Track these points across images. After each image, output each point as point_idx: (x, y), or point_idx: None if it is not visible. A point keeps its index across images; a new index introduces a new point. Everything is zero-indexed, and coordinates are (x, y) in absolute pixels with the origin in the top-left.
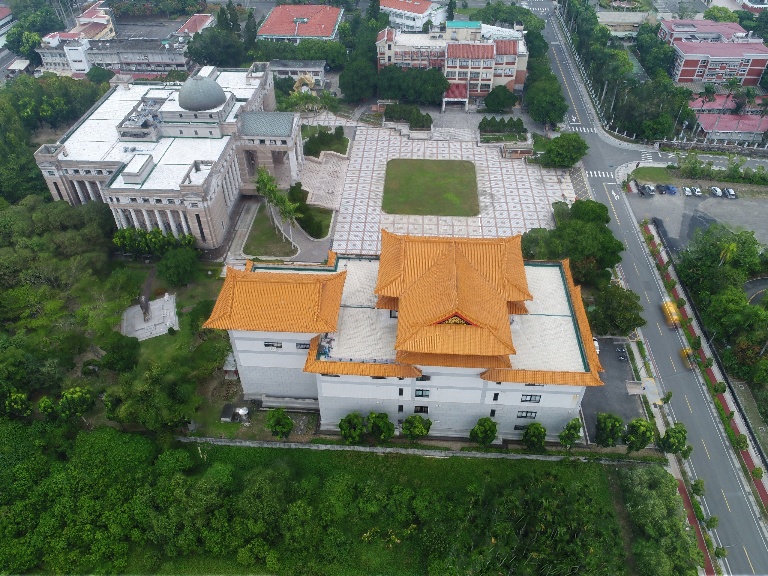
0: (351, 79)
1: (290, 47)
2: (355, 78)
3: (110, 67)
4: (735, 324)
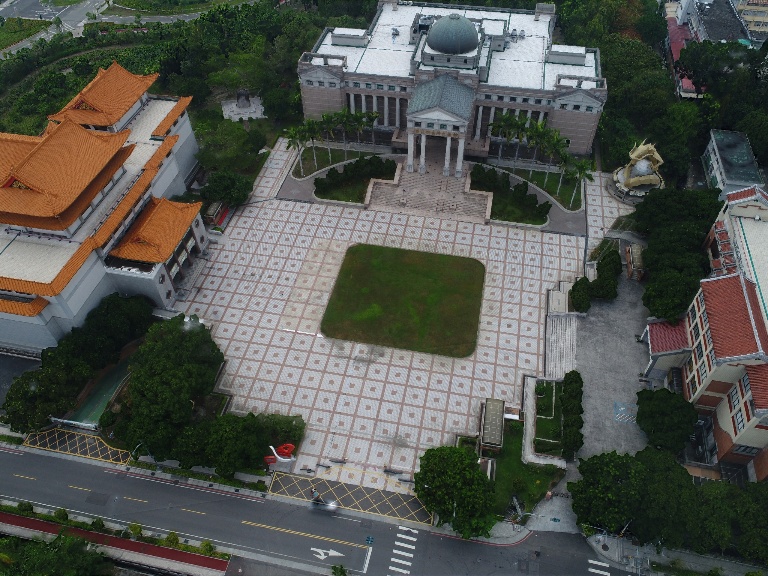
0: None
1: None
2: (653, 195)
3: (692, 31)
4: None
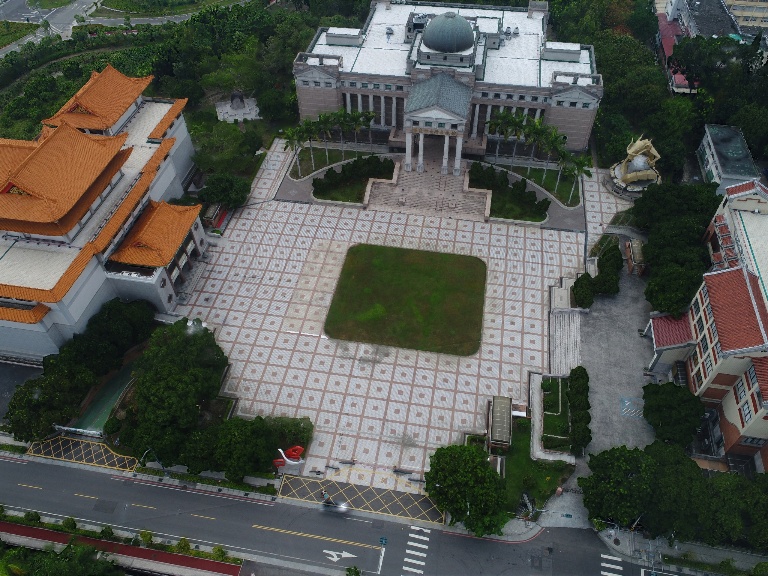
0: None
1: None
2: (652, 190)
3: (682, 27)
4: None
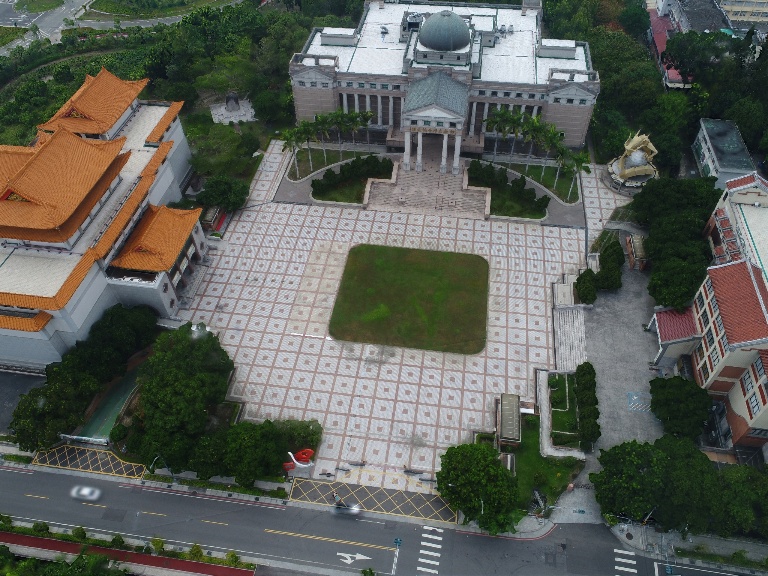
0: None
1: None
2: (651, 185)
3: (673, 22)
4: None
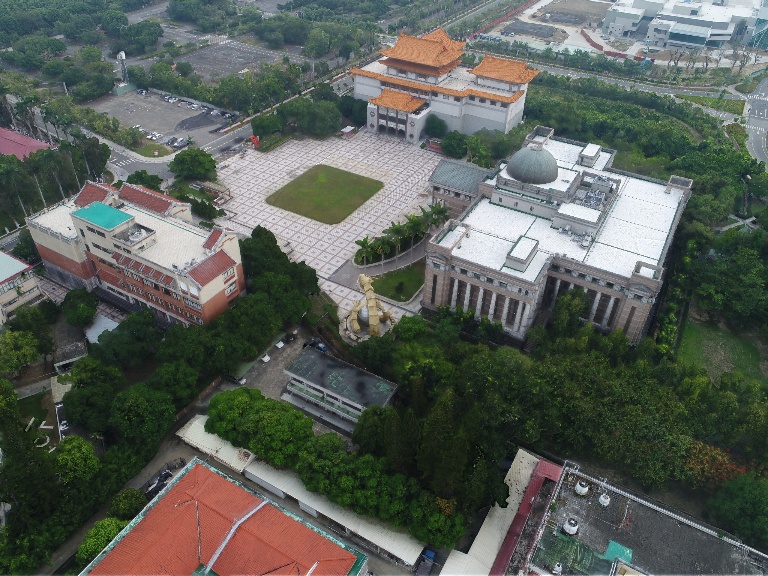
0: (307, 268)
1: (317, 440)
2: None
3: None
4: (282, 81)
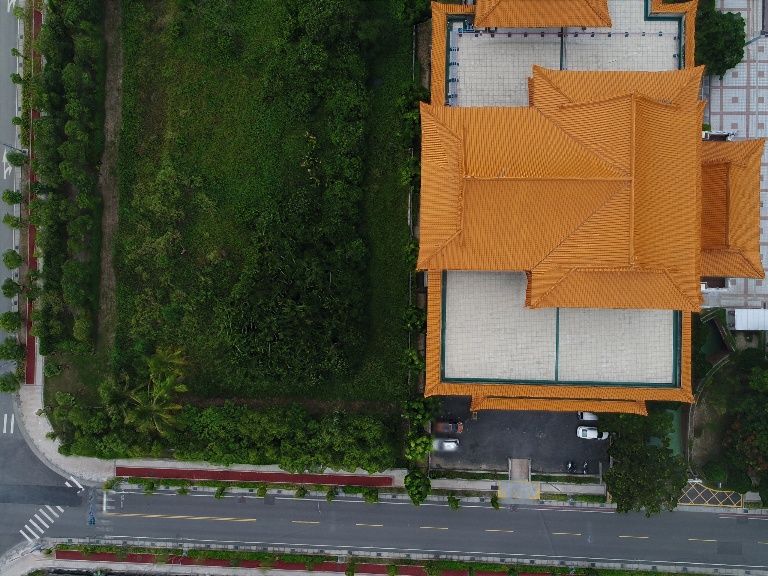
0: None
1: None
2: None
3: None
4: None
